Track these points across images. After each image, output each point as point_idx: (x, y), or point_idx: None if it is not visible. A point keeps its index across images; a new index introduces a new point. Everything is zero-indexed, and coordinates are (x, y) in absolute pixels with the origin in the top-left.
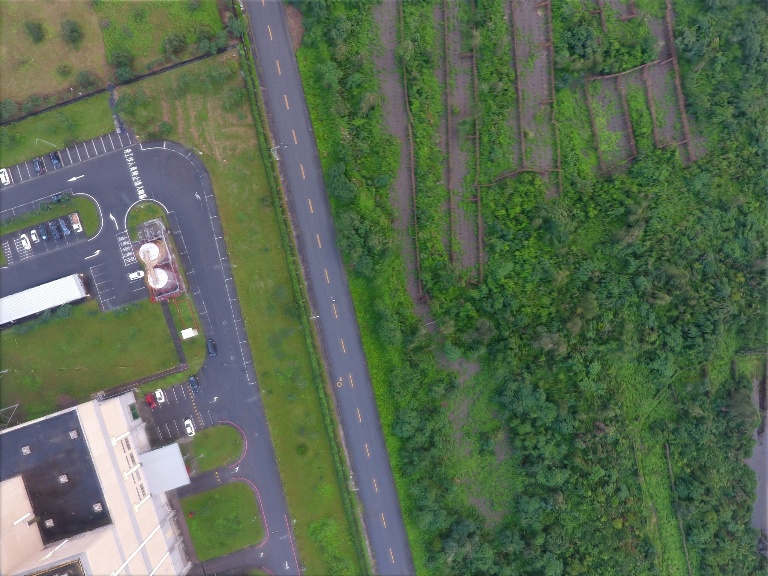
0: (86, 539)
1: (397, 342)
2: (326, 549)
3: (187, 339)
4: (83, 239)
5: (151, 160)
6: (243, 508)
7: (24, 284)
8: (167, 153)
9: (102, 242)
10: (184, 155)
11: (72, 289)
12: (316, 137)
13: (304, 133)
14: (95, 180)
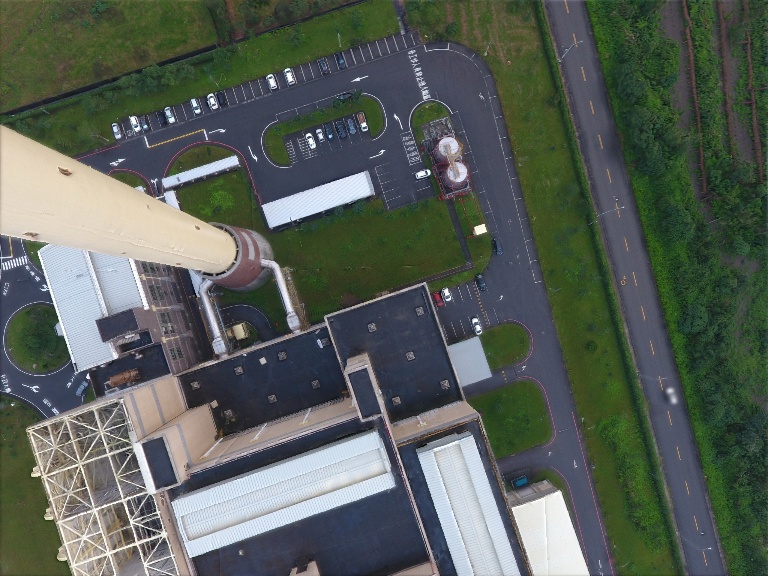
0: (450, 410)
1: (689, 237)
2: (619, 445)
3: (474, 237)
4: (367, 139)
5: (435, 61)
6: (531, 407)
7: (308, 183)
8: (451, 54)
9: (386, 142)
10: (468, 56)
11: (363, 186)
12: (598, 40)
13: (584, 36)
14: (379, 81)
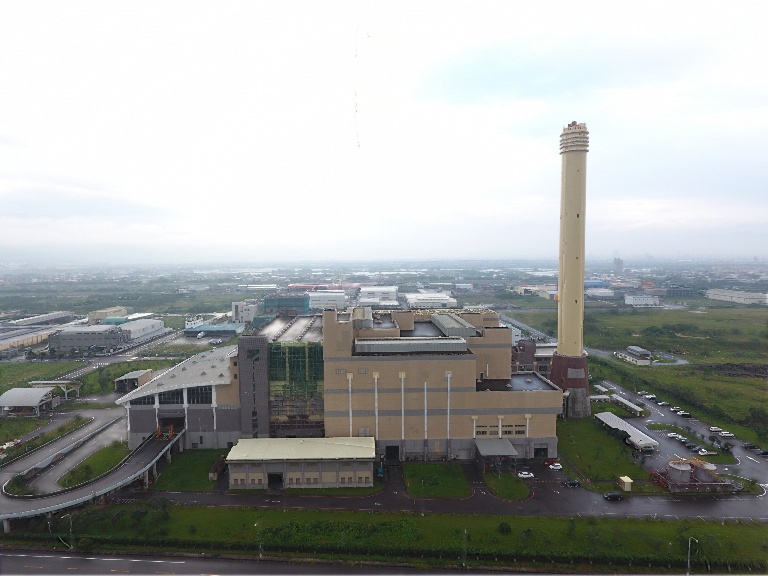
0: None
1: None
2: (388, 524)
3: (618, 484)
4: None
5: None
6: (445, 489)
7: None
8: None
9: None
10: None
11: (644, 441)
12: None
13: None
14: (759, 466)
